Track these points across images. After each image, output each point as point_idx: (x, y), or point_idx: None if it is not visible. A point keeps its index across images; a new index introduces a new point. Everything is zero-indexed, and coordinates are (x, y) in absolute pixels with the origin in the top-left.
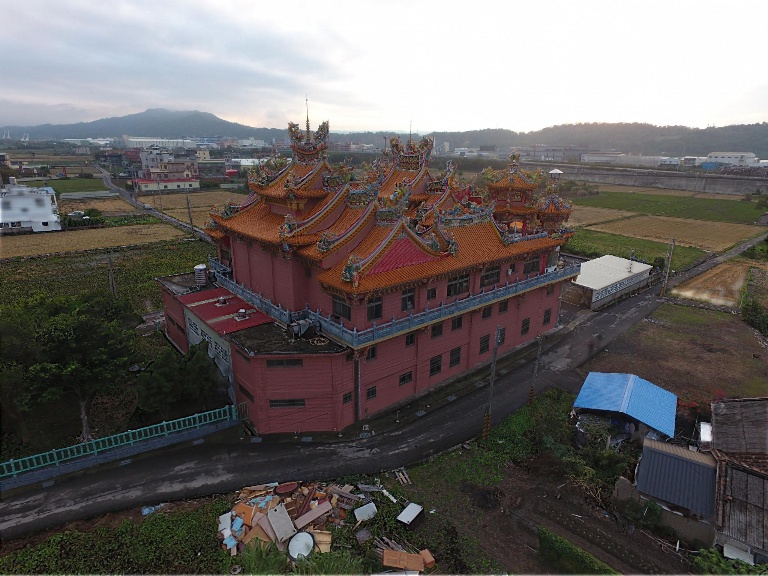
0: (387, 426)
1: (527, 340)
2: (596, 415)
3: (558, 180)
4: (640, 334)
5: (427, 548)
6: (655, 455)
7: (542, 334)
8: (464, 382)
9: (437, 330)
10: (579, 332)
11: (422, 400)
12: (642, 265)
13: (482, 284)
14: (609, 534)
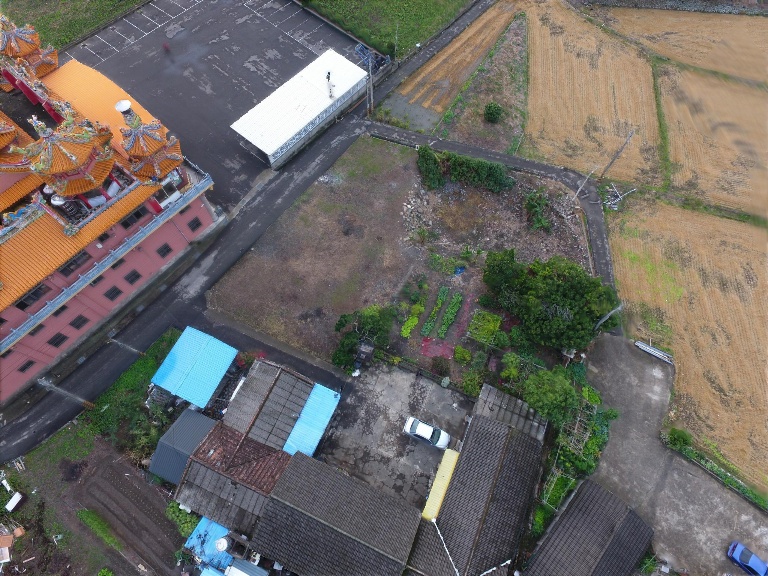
0: (18, 411)
1: (176, 254)
2: (163, 389)
3: (130, 116)
4: (298, 212)
5: (24, 521)
6: (163, 447)
7: (195, 239)
8: (99, 334)
9: (36, 328)
10: (239, 222)
11: (55, 369)
12: (356, 72)
13: (69, 272)
14: (140, 487)
